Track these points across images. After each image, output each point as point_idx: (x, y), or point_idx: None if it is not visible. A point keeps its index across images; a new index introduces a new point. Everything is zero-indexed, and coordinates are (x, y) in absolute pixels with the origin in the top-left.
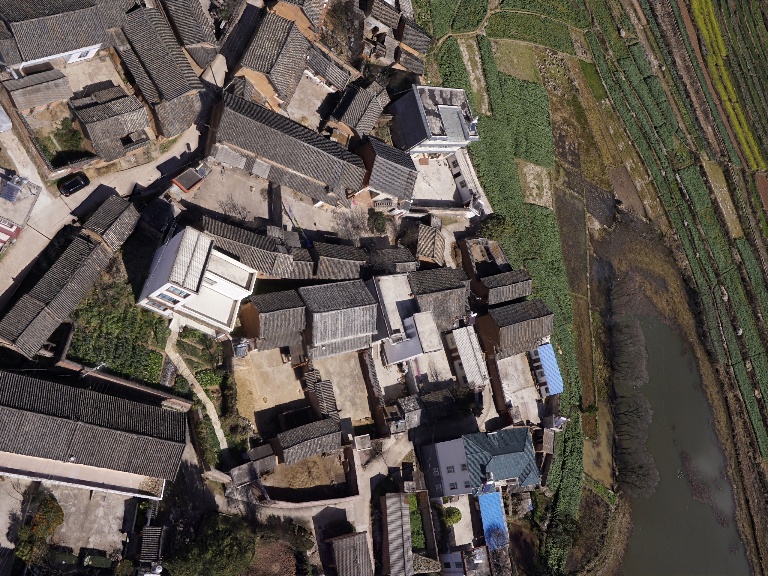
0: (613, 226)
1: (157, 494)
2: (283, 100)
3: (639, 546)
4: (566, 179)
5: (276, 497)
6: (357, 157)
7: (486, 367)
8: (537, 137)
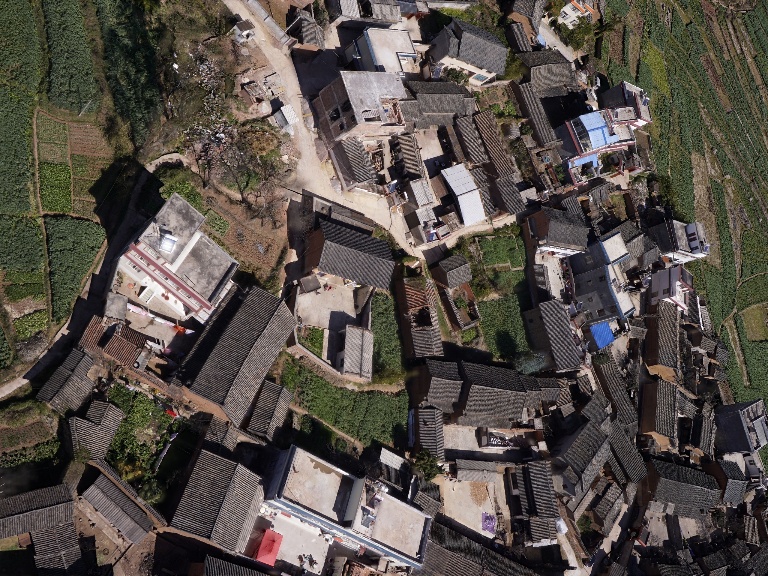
0: None
1: None
2: None
3: None
4: None
5: None
6: (712, 478)
7: None
8: None
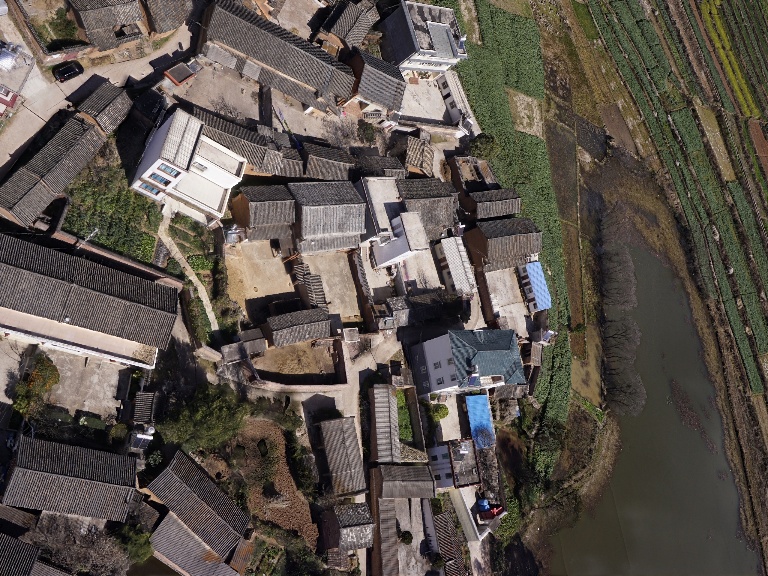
0: (604, 160)
1: (150, 363)
2: (273, 7)
3: (627, 463)
4: (557, 112)
5: (266, 380)
6: (346, 66)
7: (475, 280)
8: (528, 69)
